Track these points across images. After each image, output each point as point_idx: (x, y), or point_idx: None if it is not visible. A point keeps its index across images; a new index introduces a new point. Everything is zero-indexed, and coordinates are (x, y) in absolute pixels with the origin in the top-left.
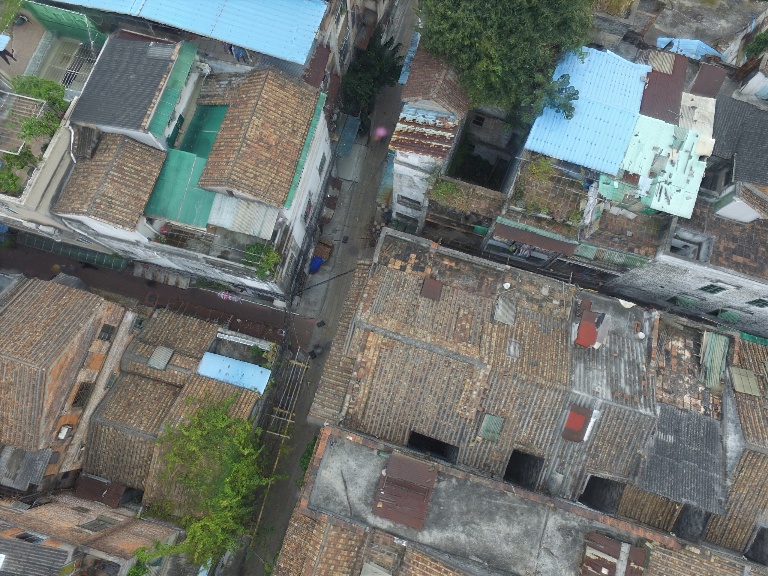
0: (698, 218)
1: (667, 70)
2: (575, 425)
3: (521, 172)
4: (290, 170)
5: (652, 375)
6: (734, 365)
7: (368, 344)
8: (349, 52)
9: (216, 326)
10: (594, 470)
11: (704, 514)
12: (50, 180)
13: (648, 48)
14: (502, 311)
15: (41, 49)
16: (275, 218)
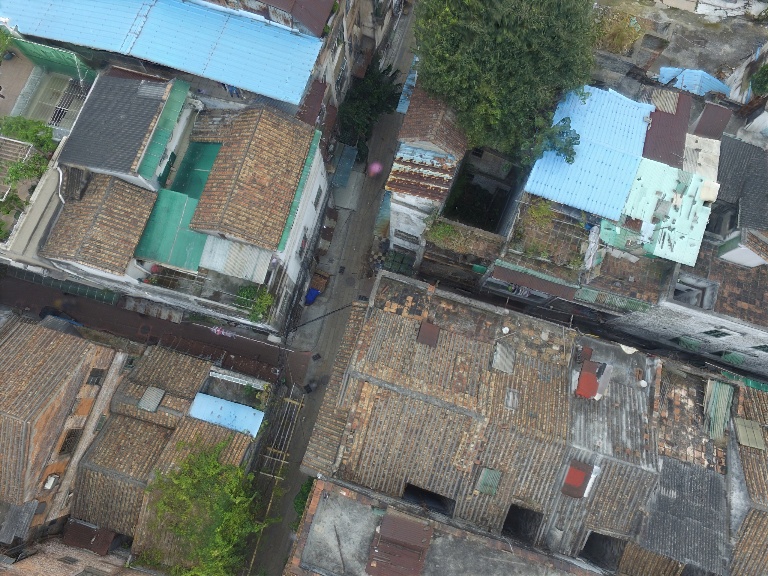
0: (702, 262)
1: (671, 110)
2: (575, 481)
3: (521, 214)
4: (284, 212)
5: (654, 427)
6: (739, 416)
7: (363, 394)
8: (346, 80)
9: (209, 364)
10: (594, 526)
11: (707, 572)
12: (37, 223)
13: (651, 83)
14: (500, 358)
15: (30, 85)
16: (268, 261)
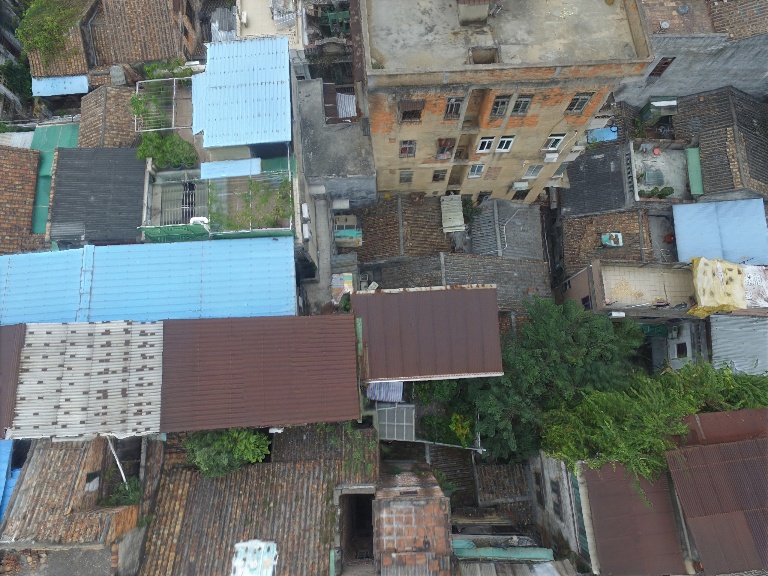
0: None
1: None
2: None
3: None
4: None
5: None
6: None
7: None
8: None
9: None
10: None
11: None
12: None
13: None
14: None
15: None
16: None
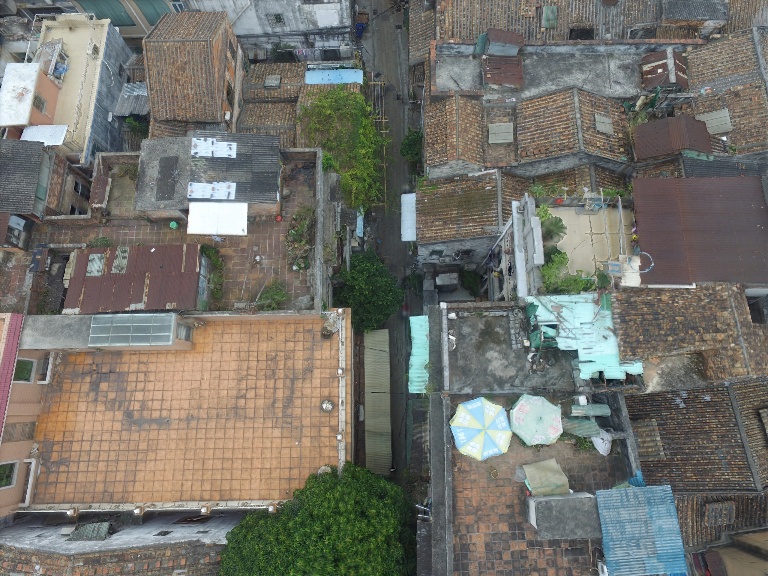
0: None
1: None
2: None
3: None
4: None
5: None
6: None
7: None
8: None
9: (304, 63)
10: (631, 25)
11: None
12: None
13: None
14: None
15: None
16: None
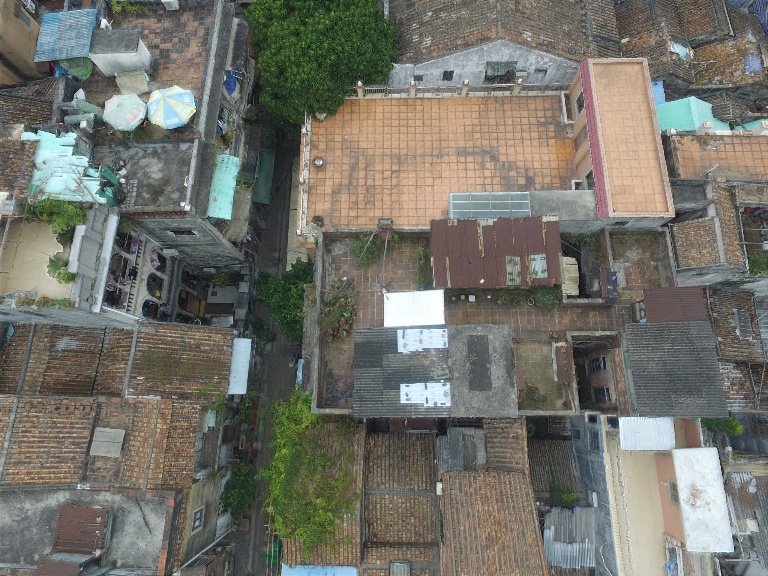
0: None
1: None
2: None
3: None
4: None
5: None
6: None
7: None
8: None
9: None
10: None
11: None
12: None
13: None
14: None
15: None
16: None
